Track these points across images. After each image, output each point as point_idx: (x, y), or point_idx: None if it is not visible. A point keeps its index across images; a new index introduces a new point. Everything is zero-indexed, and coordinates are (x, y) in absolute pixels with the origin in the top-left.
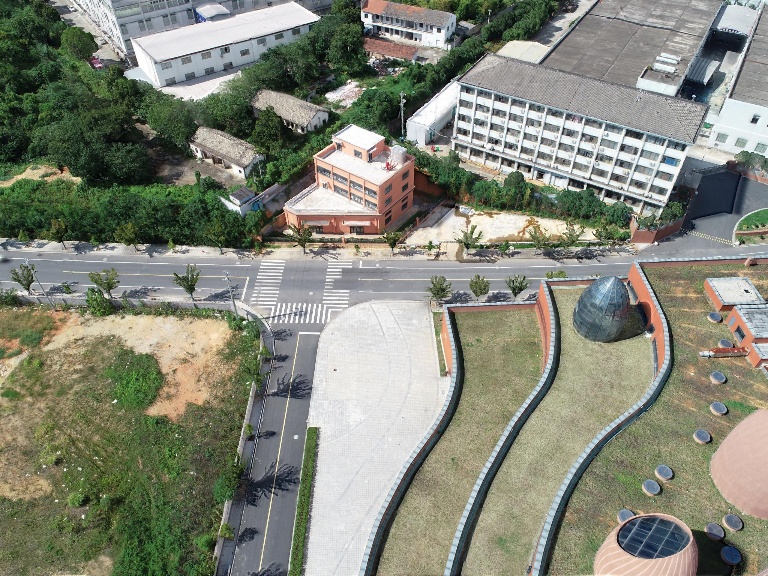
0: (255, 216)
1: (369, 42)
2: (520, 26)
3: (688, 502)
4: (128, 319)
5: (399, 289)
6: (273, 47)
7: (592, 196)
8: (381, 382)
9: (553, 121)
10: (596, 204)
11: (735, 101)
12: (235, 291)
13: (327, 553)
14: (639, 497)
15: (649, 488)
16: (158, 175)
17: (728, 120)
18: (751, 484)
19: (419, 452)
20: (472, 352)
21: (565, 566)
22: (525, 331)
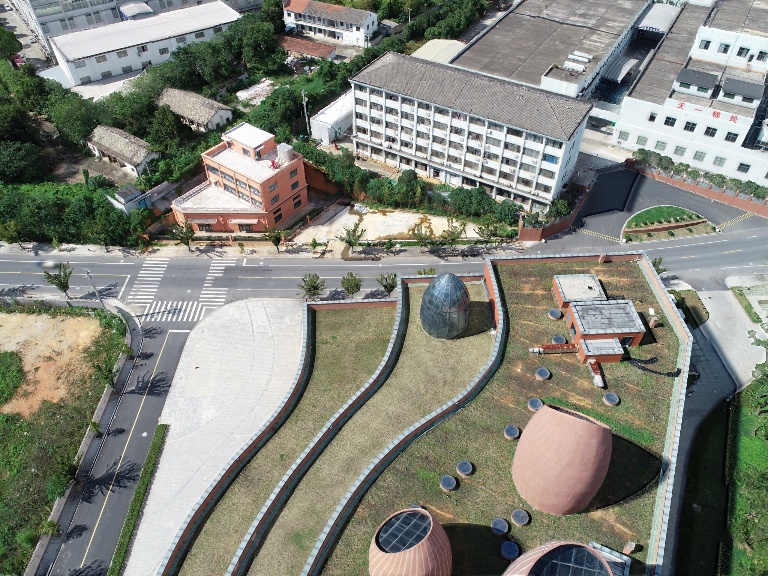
0: (139, 214)
1: (289, 41)
2: (443, 25)
3: (482, 497)
4: (0, 317)
5: (278, 287)
6: (184, 46)
7: (482, 194)
8: (240, 379)
9: (441, 119)
10: (486, 202)
11: (632, 99)
12: (113, 289)
13: (151, 550)
14: (435, 493)
15: (445, 484)
16: (53, 173)
17: (628, 118)
18: (532, 479)
19: (246, 449)
20: (325, 349)
21: (343, 561)
22: (382, 328)
